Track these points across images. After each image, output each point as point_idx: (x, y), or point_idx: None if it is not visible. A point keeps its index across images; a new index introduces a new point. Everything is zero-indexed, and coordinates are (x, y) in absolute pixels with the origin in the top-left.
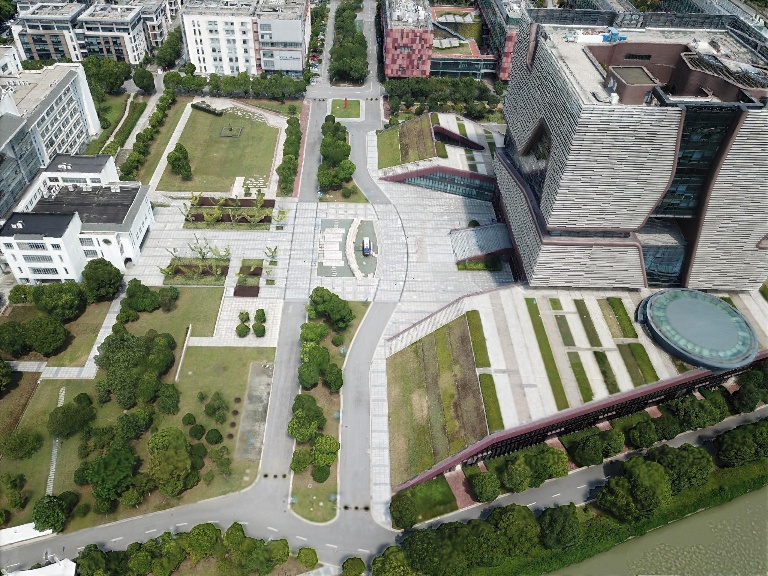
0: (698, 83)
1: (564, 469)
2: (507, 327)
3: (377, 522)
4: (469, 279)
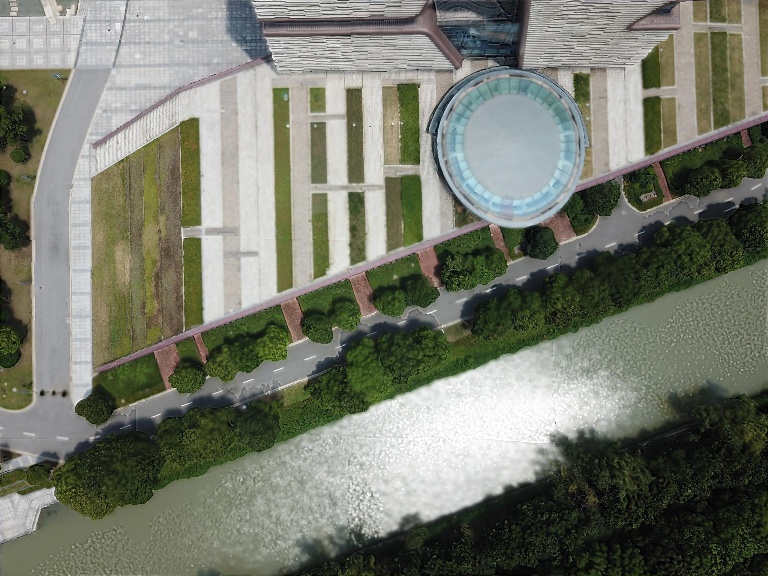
0: None
1: (280, 356)
2: (236, 150)
3: None
4: (223, 14)
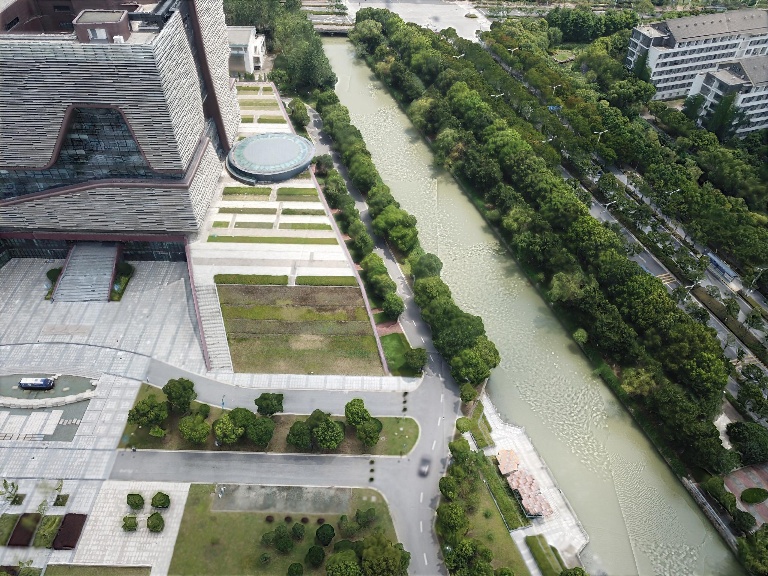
0: (116, 2)
1: None
2: (241, 259)
3: (416, 388)
4: (137, 294)
